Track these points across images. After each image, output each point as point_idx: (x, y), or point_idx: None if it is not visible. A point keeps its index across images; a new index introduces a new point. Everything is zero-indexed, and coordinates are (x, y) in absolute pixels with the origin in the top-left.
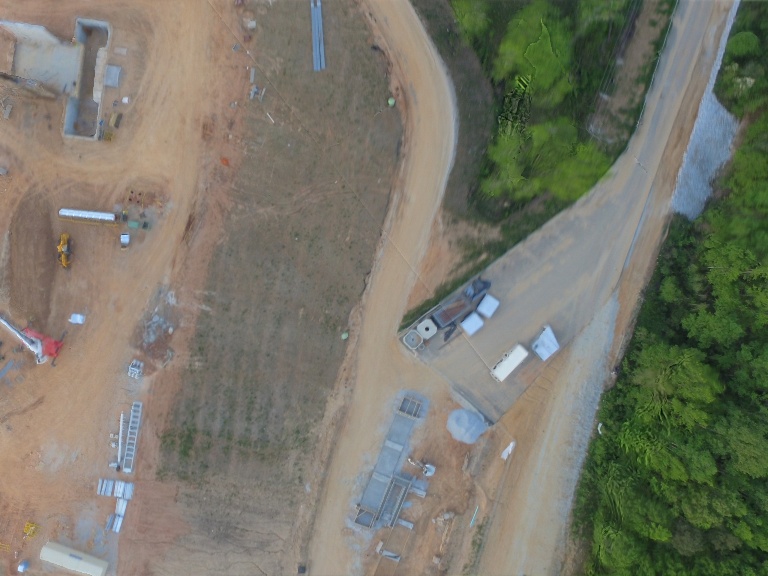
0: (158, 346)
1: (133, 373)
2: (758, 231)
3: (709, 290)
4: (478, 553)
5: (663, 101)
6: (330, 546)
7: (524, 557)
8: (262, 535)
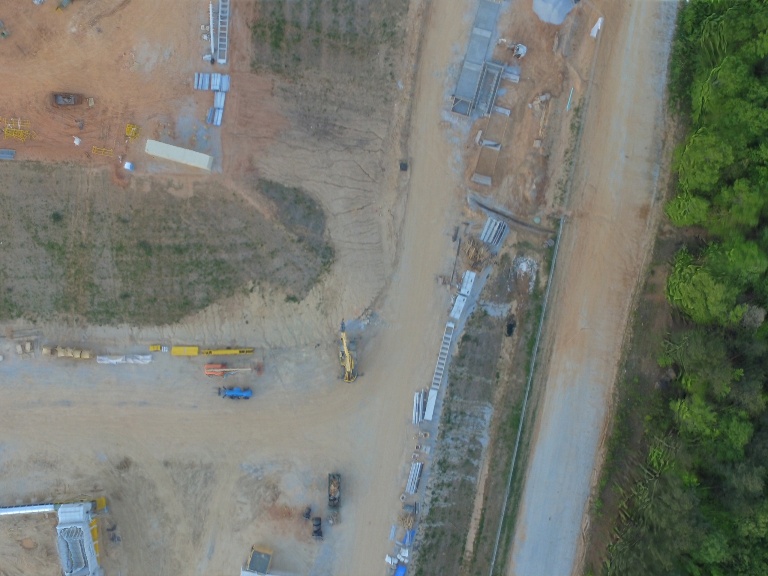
0: None
1: None
2: None
3: None
4: (578, 136)
5: None
6: (429, 142)
7: (624, 136)
8: (360, 133)
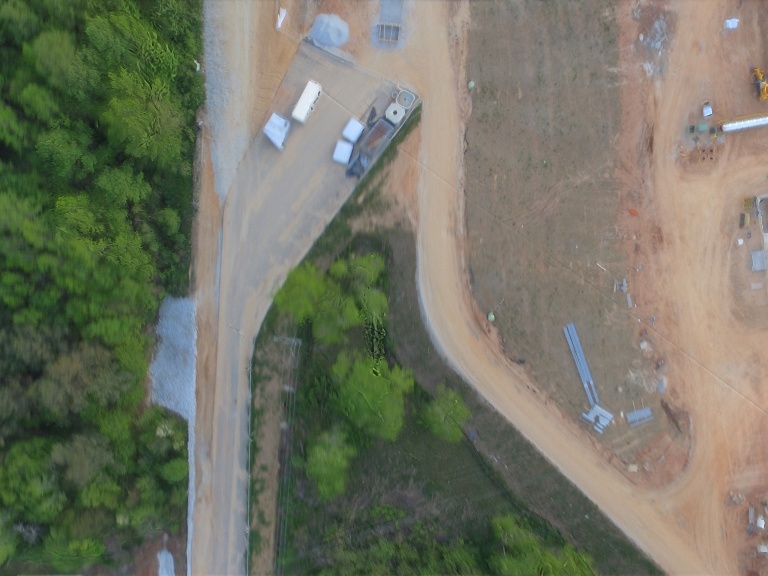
0: (650, 19)
1: None
2: (113, 287)
3: (136, 225)
4: None
5: (233, 397)
6: None
7: None
8: None
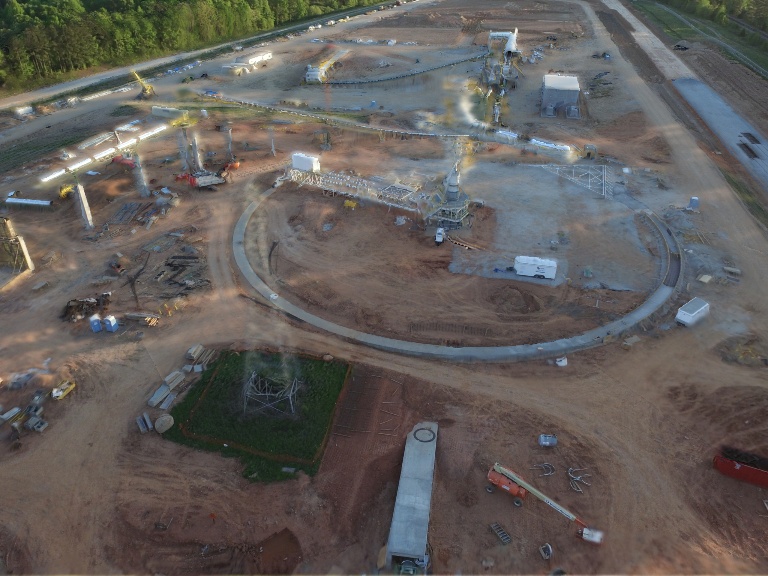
0: None
1: (72, 155)
2: None
3: None
4: None
5: None
6: None
7: None
8: None
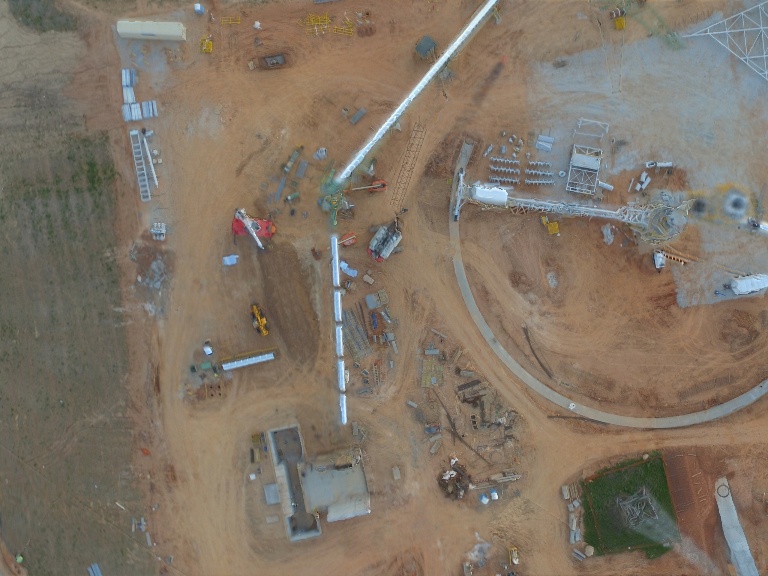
0: (147, 260)
1: (160, 227)
2: None
3: None
4: None
5: None
6: None
7: None
8: (1, 106)
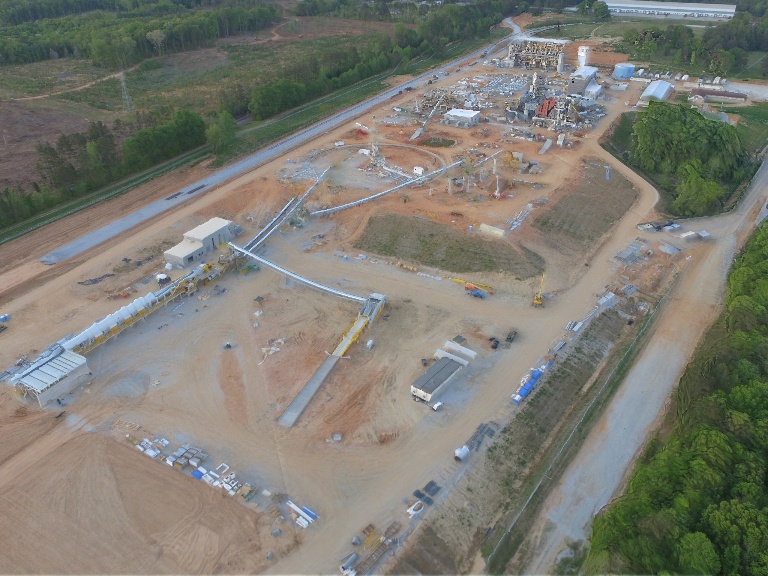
0: None
1: None
2: None
3: None
4: None
5: None
6: (601, 263)
7: (702, 284)
8: None
